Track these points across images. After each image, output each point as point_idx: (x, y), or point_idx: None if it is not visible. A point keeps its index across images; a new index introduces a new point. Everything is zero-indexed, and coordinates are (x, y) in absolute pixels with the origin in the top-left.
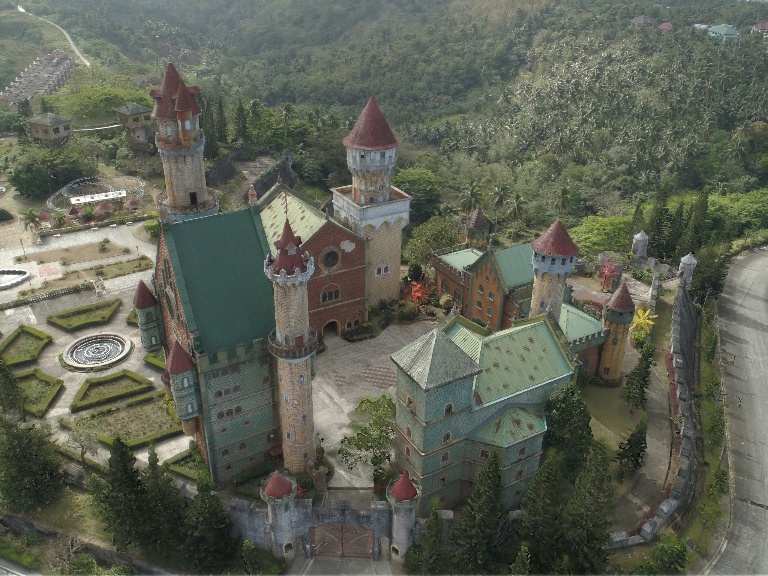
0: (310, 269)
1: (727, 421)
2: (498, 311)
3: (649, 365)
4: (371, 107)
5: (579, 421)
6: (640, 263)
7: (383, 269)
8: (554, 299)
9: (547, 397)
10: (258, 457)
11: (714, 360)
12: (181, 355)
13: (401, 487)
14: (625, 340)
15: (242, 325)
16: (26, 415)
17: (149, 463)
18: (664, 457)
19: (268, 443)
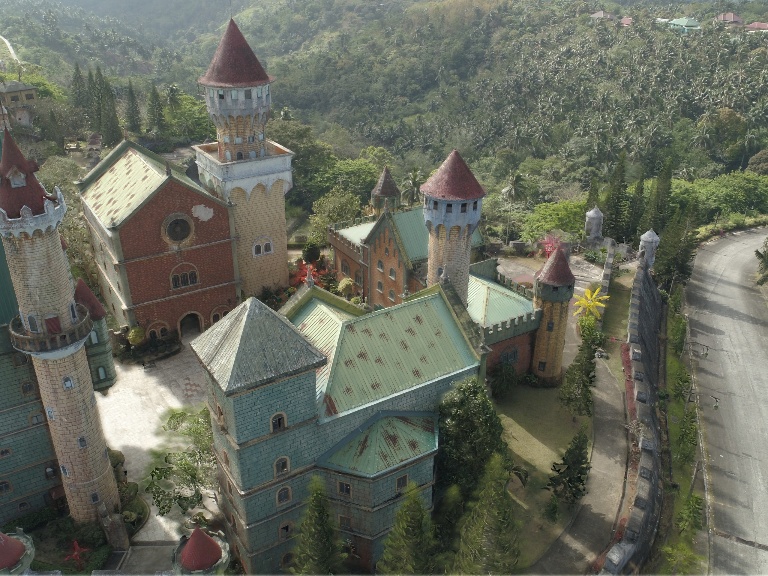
0: (51, 210)
1: (701, 428)
2: None
3: (593, 354)
4: (230, 32)
5: (485, 434)
6: (595, 245)
7: (263, 247)
8: (456, 264)
9: (442, 401)
10: (34, 501)
11: (683, 352)
12: None
13: (191, 549)
14: (564, 324)
15: None
16: None
17: None
18: None
19: (47, 480)
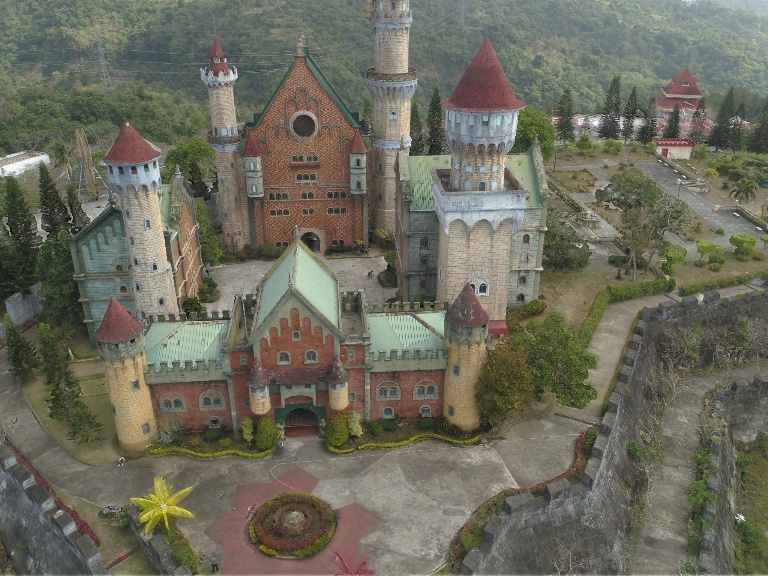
0: None
1: None
2: None
3: None
4: None
5: None
6: None
7: None
8: None
9: None
10: None
11: None
12: None
13: None
14: None
15: None
16: None
17: None
18: (4, 416)
19: None
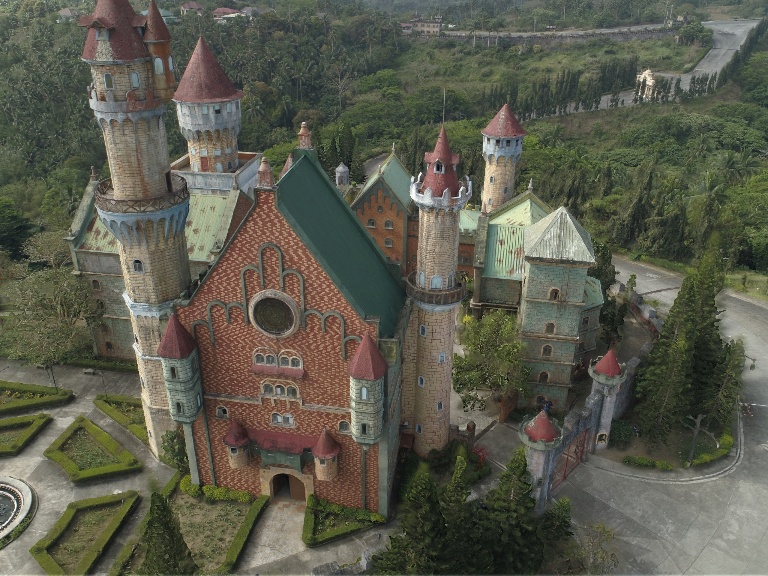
0: None
1: None
2: (401, 236)
3: None
4: (205, 50)
5: None
6: None
7: None
8: None
9: None
10: None
11: None
12: (377, 350)
13: (614, 364)
14: None
15: (378, 295)
16: None
17: (461, 482)
18: None
19: (398, 438)
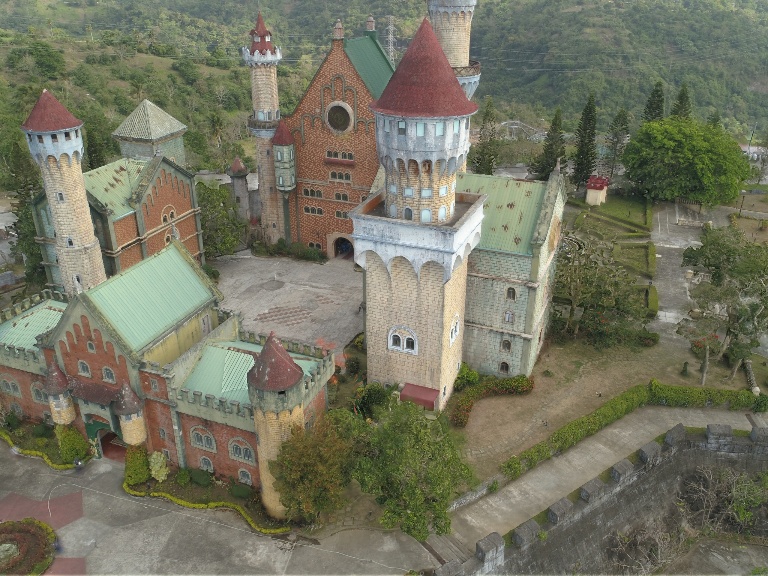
0: None
1: None
2: None
3: None
4: None
5: None
6: None
7: None
8: None
9: None
10: None
11: None
12: None
13: None
14: None
15: None
16: None
17: None
18: None
19: None
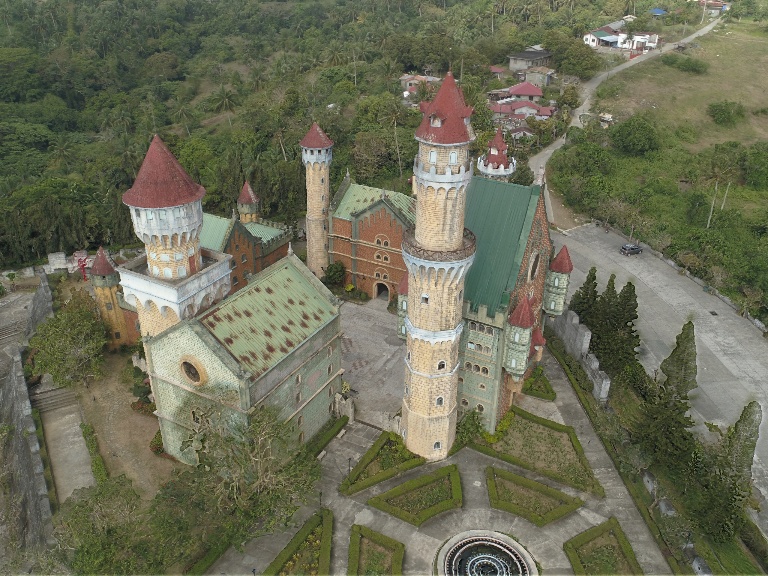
0: None
1: None
2: None
3: None
4: None
5: None
6: None
7: None
8: None
9: None
10: None
11: None
12: None
13: None
14: None
15: None
16: (628, 539)
17: None
18: None
19: None
